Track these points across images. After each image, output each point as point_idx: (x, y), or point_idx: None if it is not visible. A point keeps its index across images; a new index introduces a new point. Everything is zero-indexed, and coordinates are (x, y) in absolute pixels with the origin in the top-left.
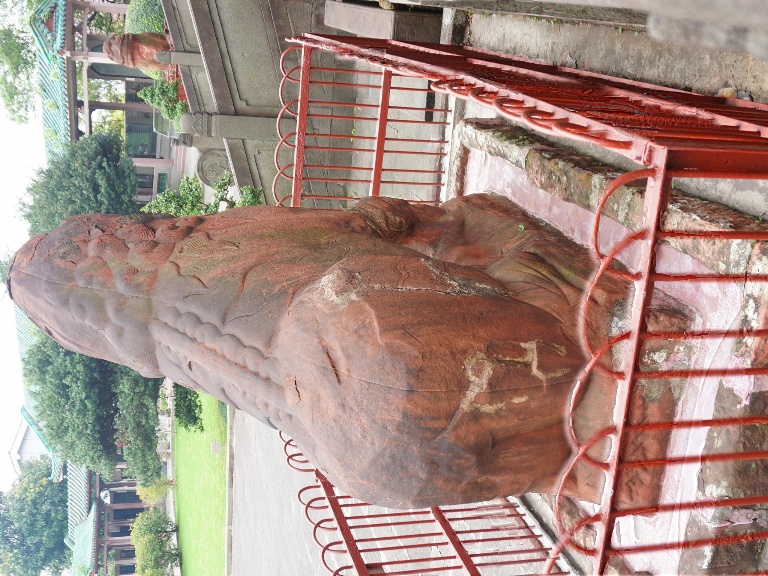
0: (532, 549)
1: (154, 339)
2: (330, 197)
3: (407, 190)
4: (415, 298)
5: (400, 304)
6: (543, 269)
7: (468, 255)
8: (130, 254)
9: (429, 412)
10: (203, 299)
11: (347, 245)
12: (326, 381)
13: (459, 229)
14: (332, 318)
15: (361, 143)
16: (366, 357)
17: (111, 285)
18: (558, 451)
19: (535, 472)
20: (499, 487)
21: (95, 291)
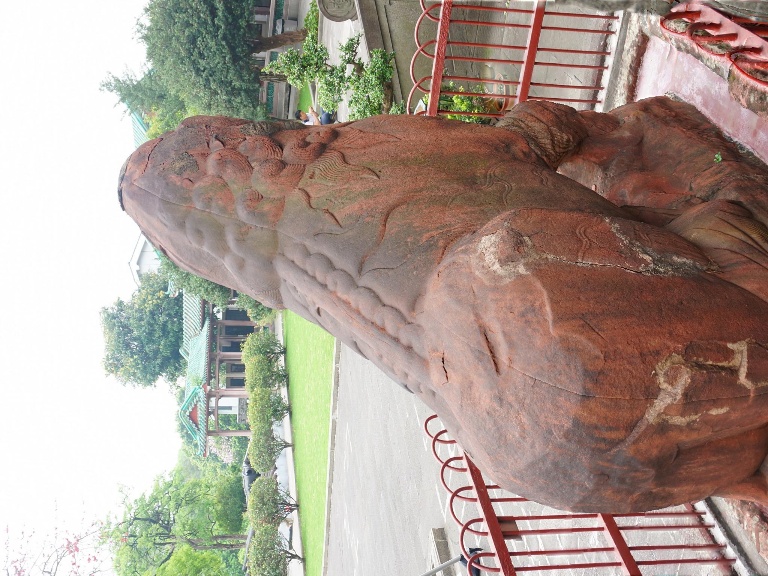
0: (683, 512)
1: (279, 276)
2: (475, 79)
3: (564, 73)
4: (598, 278)
5: (580, 285)
6: (753, 231)
7: (647, 186)
8: (254, 176)
9: (606, 421)
10: (337, 241)
11: (508, 181)
12: (481, 368)
13: (636, 148)
14: (493, 293)
15: (516, 17)
16: (533, 349)
17: (232, 211)
18: (751, 459)
19: (720, 481)
20: (676, 497)
21: (214, 216)
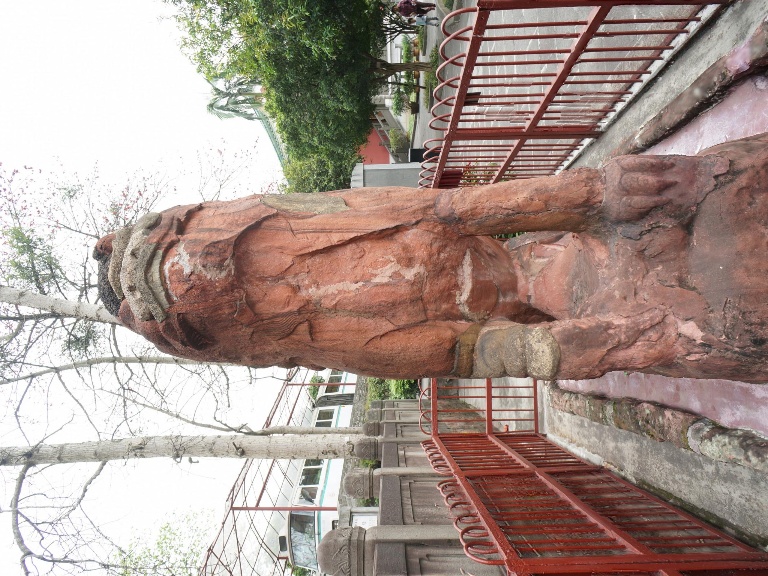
0: (611, 97)
1: None
2: None
3: None
4: None
5: None
6: None
7: None
8: None
9: None
10: None
11: None
12: None
13: None
14: None
15: None
16: None
17: None
18: None
19: None
20: None
21: None
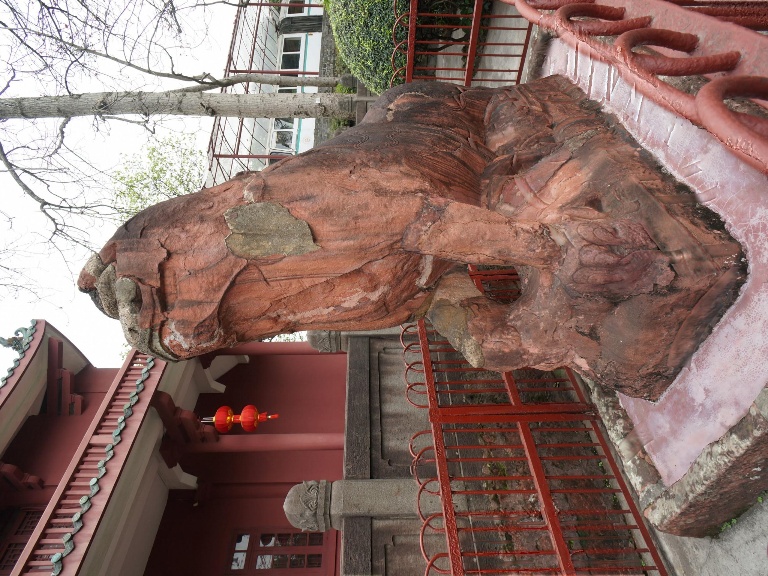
0: None
1: None
2: None
3: None
4: None
5: None
6: None
7: None
8: None
9: None
10: None
11: None
12: None
13: None
14: None
15: None
16: None
17: None
18: None
19: None
20: None
21: None
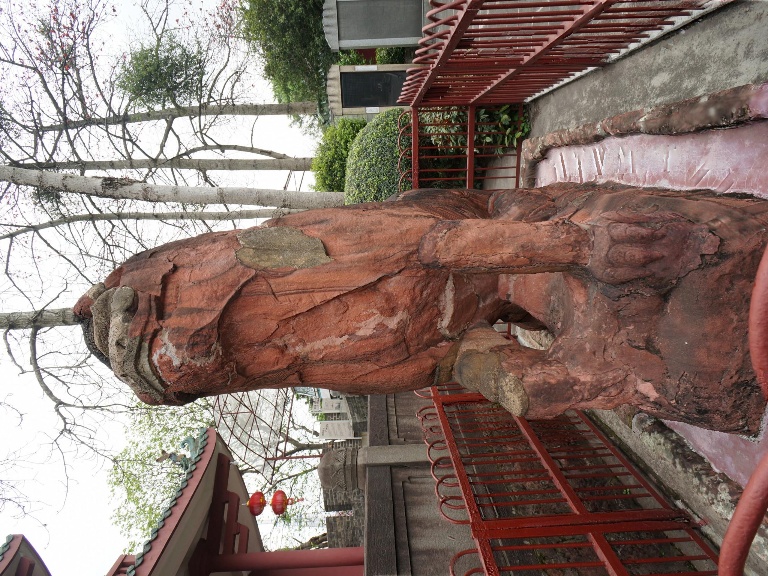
0: None
1: None
2: None
3: None
4: None
5: None
6: None
7: None
8: None
9: None
10: None
11: None
12: None
13: None
14: None
15: None
16: None
17: None
18: None
19: None
20: None
21: None
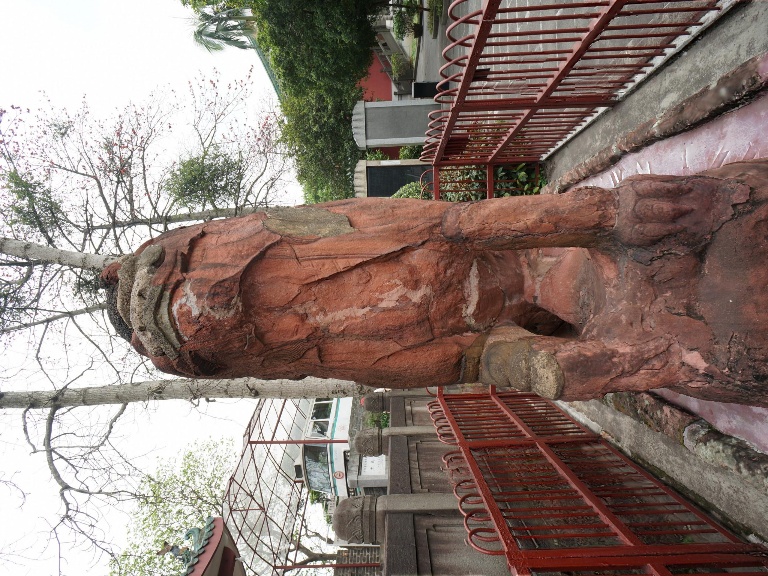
0: None
1: None
2: None
3: None
4: None
5: None
6: None
7: None
8: None
9: None
10: None
11: None
12: None
13: None
14: None
15: None
16: None
17: None
18: None
19: None
20: None
21: None
